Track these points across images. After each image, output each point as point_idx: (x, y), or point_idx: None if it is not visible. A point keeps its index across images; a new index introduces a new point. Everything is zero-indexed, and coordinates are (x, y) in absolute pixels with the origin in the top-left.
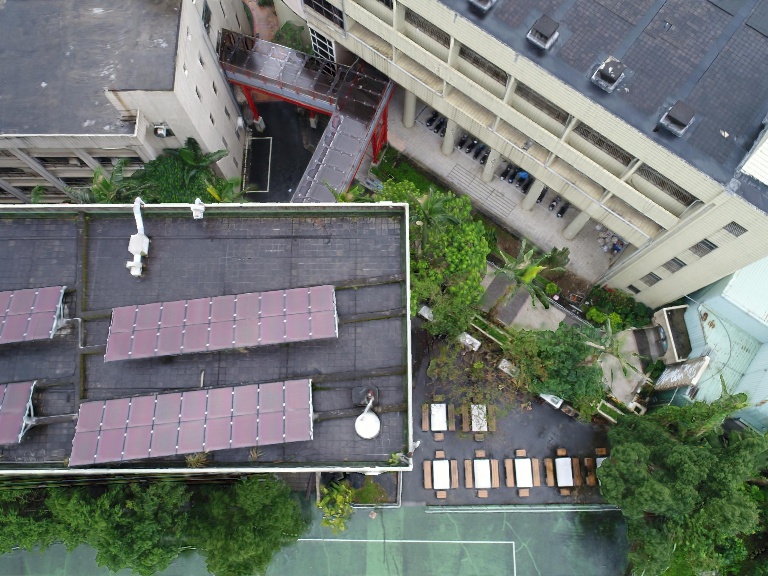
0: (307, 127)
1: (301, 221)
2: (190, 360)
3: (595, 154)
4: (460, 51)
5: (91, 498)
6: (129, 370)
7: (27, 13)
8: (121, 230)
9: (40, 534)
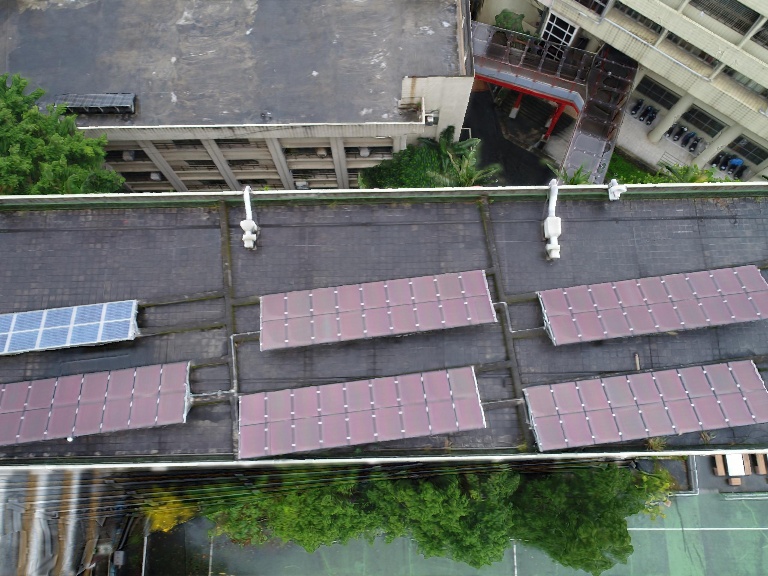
0: (504, 117)
1: (704, 201)
2: (620, 343)
3: None
4: (756, 33)
5: (439, 488)
6: (560, 354)
7: (287, 2)
8: (523, 213)
9: (365, 527)
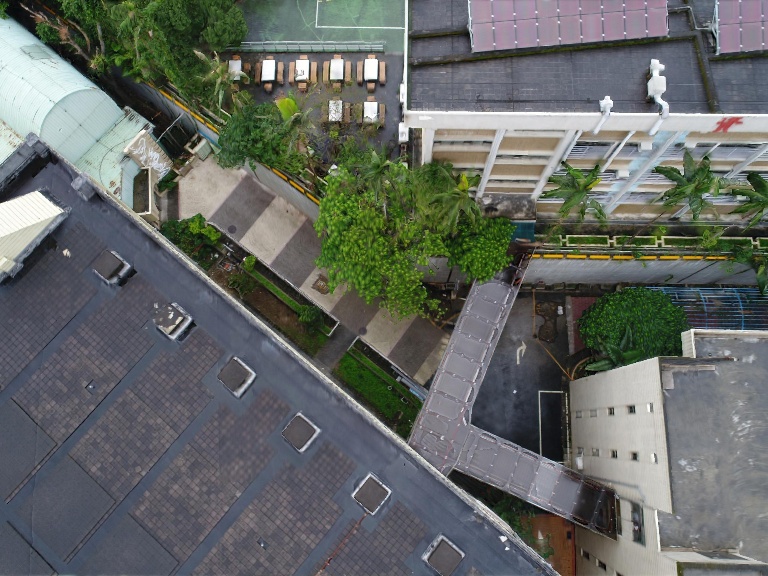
0: None
1: None
2: None
3: None
4: None
5: None
6: None
7: None
8: (677, 109)
9: None
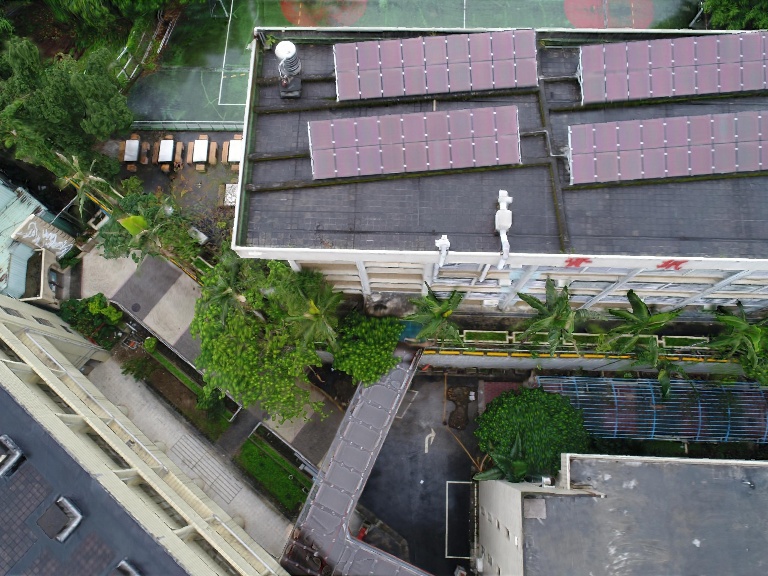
0: None
1: None
2: None
3: (51, 406)
4: None
5: None
6: None
7: None
8: (527, 243)
9: None
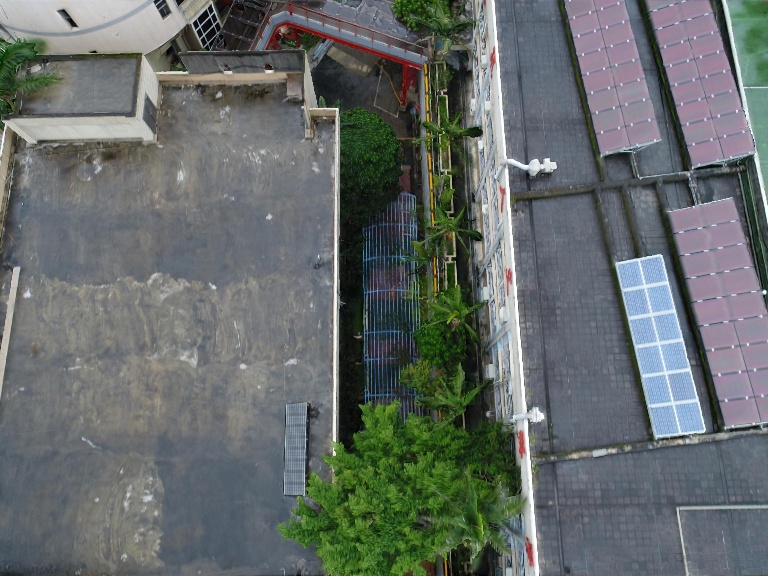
0: None
1: None
2: None
3: None
4: None
5: None
6: None
7: (178, 247)
8: None
9: None
